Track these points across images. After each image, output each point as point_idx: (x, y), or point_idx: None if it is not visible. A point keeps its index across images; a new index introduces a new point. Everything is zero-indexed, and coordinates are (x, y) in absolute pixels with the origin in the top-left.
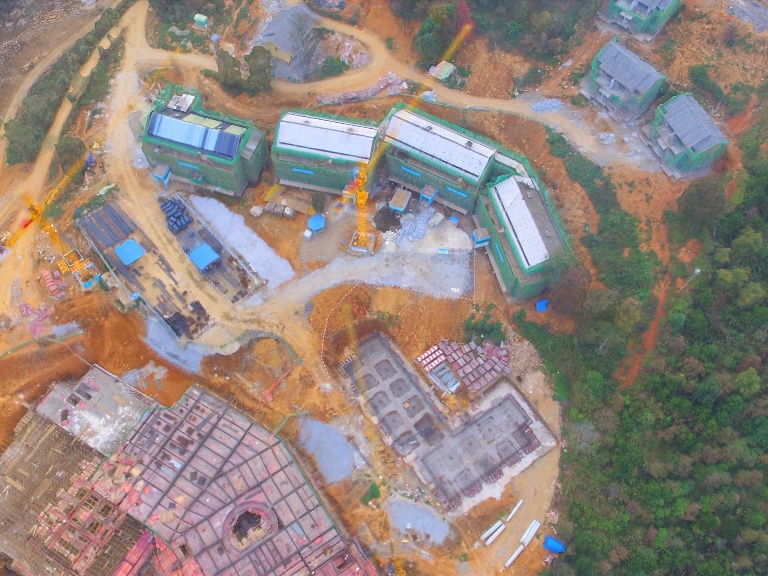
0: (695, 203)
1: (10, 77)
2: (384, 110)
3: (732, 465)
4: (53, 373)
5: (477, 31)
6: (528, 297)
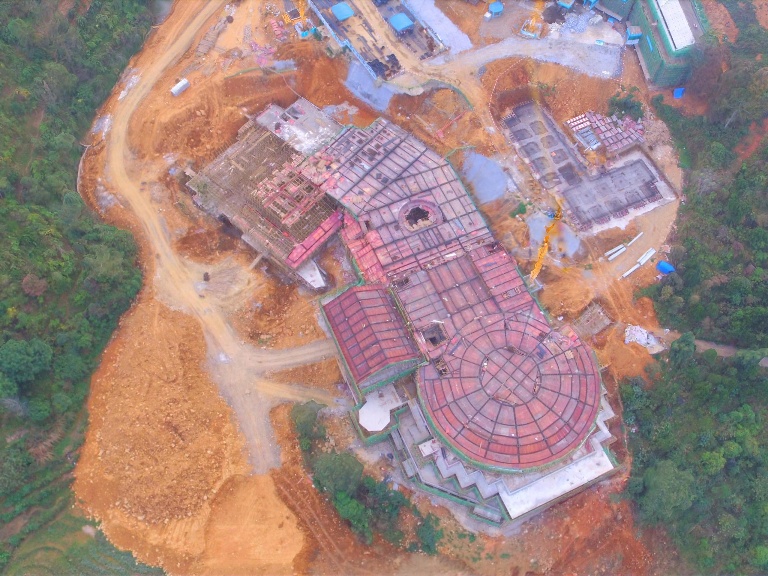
0: None
1: None
2: None
3: None
4: (270, 98)
5: None
6: (667, 85)
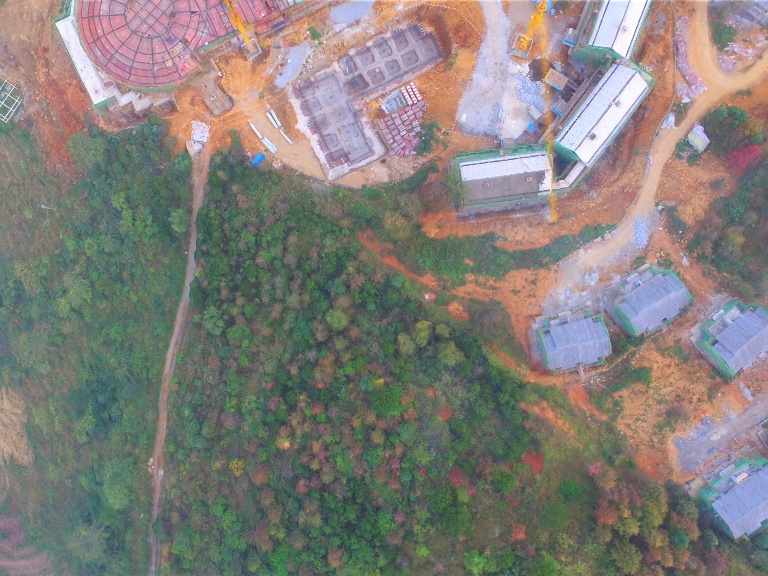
0: (486, 307)
1: None
2: (662, 79)
3: None
4: None
5: (742, 179)
6: None
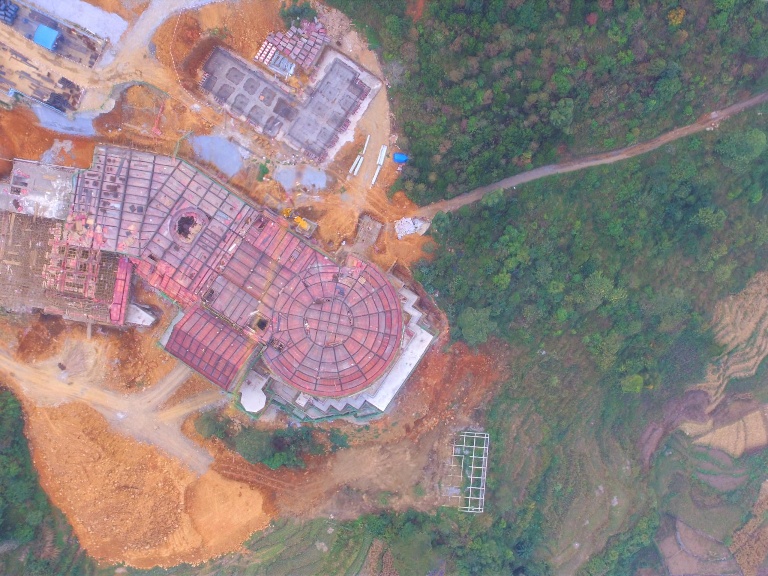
0: None
1: None
2: None
3: (510, 51)
4: None
5: None
6: None
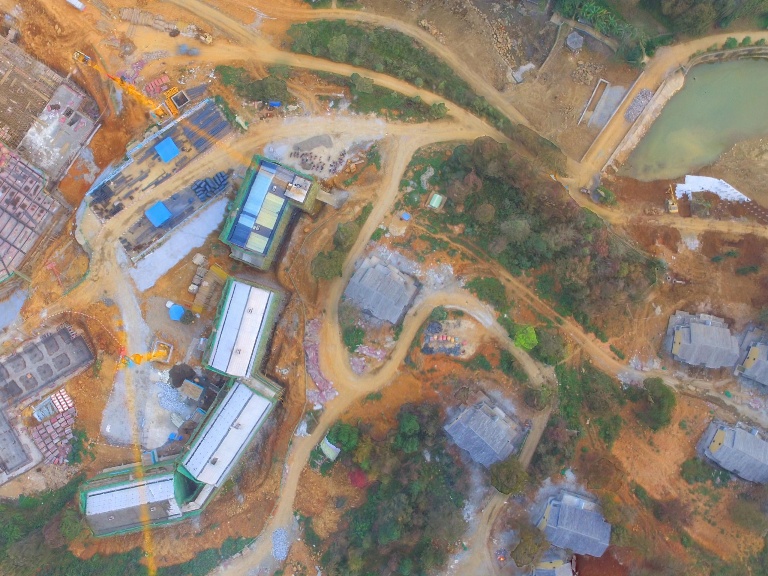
0: None
1: (416, 8)
2: (296, 383)
3: None
4: None
5: (371, 490)
6: None
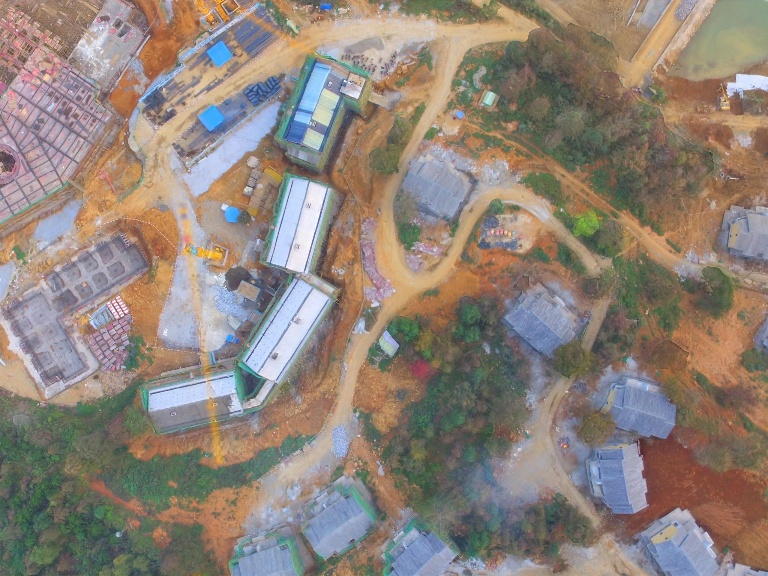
0: None
1: None
2: (352, 282)
3: None
4: (142, 4)
5: (431, 383)
6: None
